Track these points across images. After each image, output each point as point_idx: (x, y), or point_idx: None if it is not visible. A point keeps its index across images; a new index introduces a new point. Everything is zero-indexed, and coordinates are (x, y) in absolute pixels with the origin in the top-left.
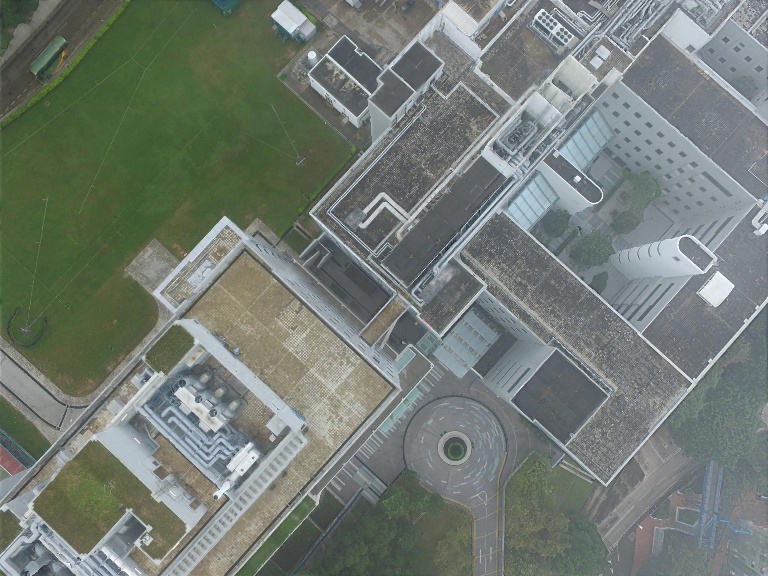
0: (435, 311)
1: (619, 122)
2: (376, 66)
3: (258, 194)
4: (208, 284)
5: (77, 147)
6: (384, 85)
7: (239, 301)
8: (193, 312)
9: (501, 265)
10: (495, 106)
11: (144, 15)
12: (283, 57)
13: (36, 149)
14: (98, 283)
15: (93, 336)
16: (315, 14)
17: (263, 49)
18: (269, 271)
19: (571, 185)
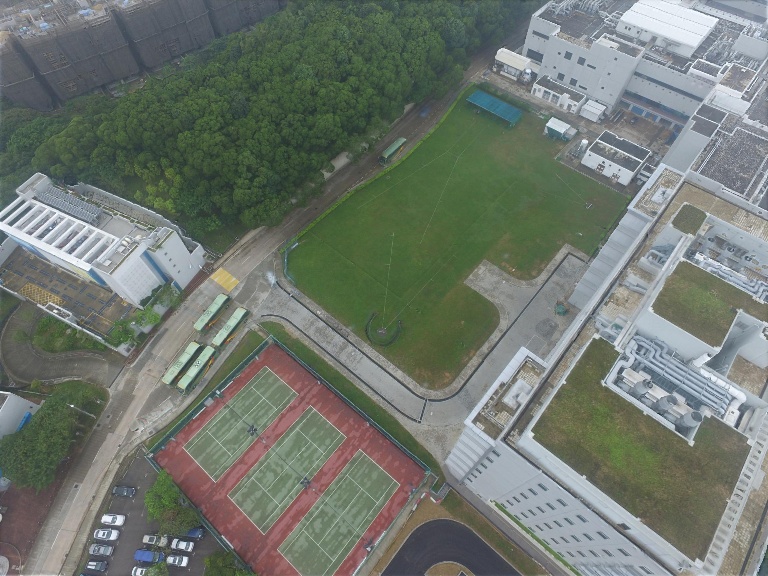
0: None
1: None
2: (635, 145)
3: (562, 227)
4: None
5: (414, 202)
6: (696, 122)
7: None
8: (664, 219)
9: None
10: None
11: (452, 130)
12: (555, 148)
13: (382, 204)
14: (443, 293)
15: (444, 335)
16: None
17: (540, 145)
18: (710, 193)
19: None
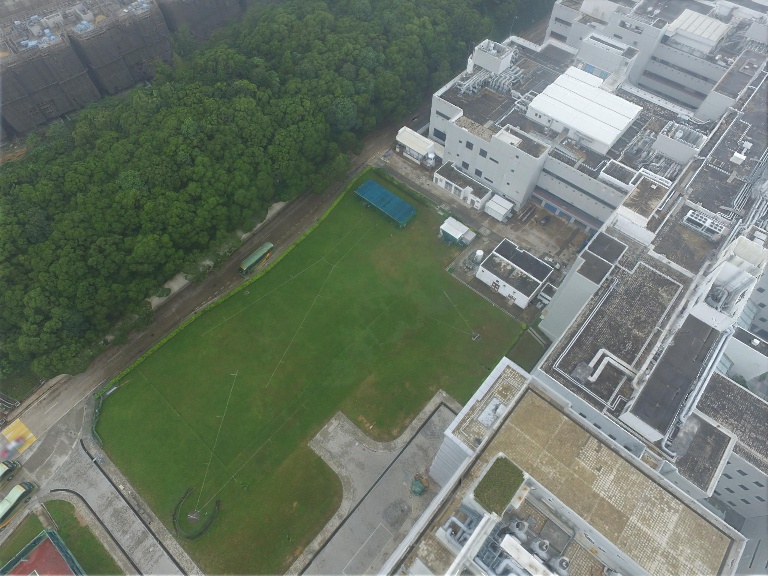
0: (690, 467)
1: (764, 297)
2: (536, 259)
3: (439, 367)
4: (499, 423)
5: (270, 328)
6: (586, 261)
7: (534, 440)
8: (488, 453)
9: (729, 420)
10: (676, 278)
11: (334, 229)
12: (449, 256)
13: (232, 330)
14: (279, 459)
15: (269, 523)
16: (471, 227)
17: (432, 251)
18: (557, 408)
19: (752, 347)
